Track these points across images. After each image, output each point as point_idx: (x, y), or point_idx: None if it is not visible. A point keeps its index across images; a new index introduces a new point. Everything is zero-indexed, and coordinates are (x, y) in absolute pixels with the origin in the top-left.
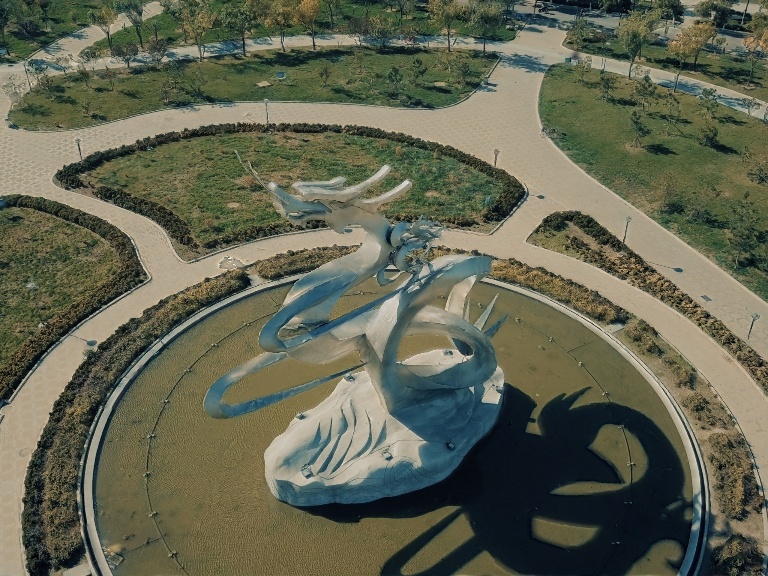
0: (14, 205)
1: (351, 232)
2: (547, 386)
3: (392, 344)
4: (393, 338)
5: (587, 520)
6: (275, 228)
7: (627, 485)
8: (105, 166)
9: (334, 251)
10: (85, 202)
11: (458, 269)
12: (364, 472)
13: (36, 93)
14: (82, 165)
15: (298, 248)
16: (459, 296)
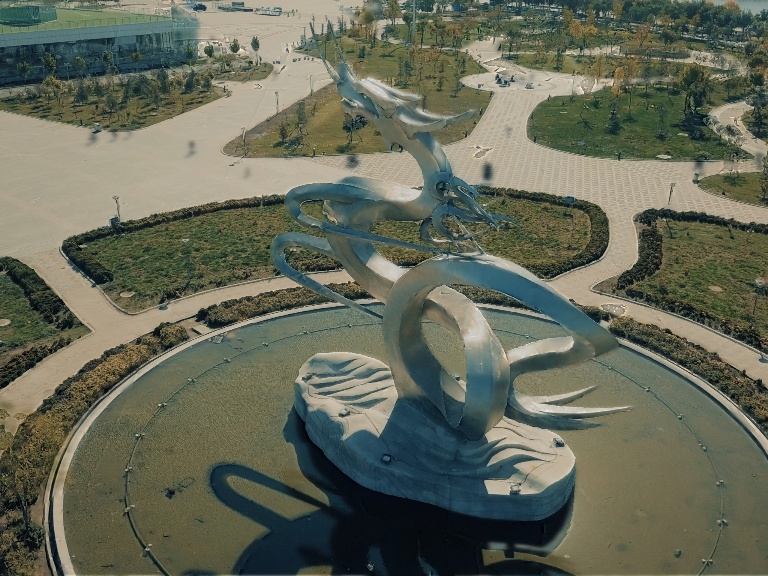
0: (584, 209)
1: (763, 362)
2: (595, 565)
3: (395, 301)
4: (397, 295)
5: None
6: (706, 318)
7: None
8: (691, 223)
9: (697, 352)
10: (627, 231)
11: (493, 272)
12: (319, 405)
13: (763, 174)
14: (674, 213)
15: (686, 336)
16: (544, 346)
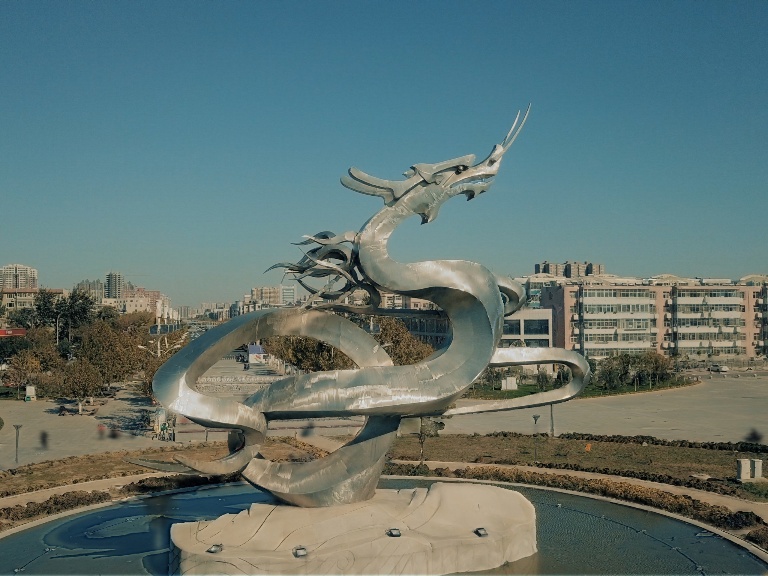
0: None
1: None
2: None
3: None
4: None
5: (226, 510)
6: None
7: (158, 515)
8: None
9: None
10: None
11: None
12: None
13: None
14: None
15: None
16: None
